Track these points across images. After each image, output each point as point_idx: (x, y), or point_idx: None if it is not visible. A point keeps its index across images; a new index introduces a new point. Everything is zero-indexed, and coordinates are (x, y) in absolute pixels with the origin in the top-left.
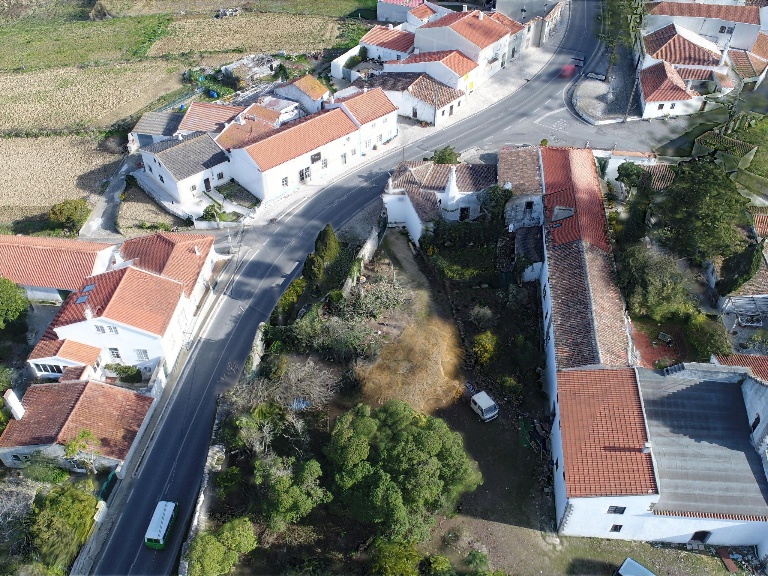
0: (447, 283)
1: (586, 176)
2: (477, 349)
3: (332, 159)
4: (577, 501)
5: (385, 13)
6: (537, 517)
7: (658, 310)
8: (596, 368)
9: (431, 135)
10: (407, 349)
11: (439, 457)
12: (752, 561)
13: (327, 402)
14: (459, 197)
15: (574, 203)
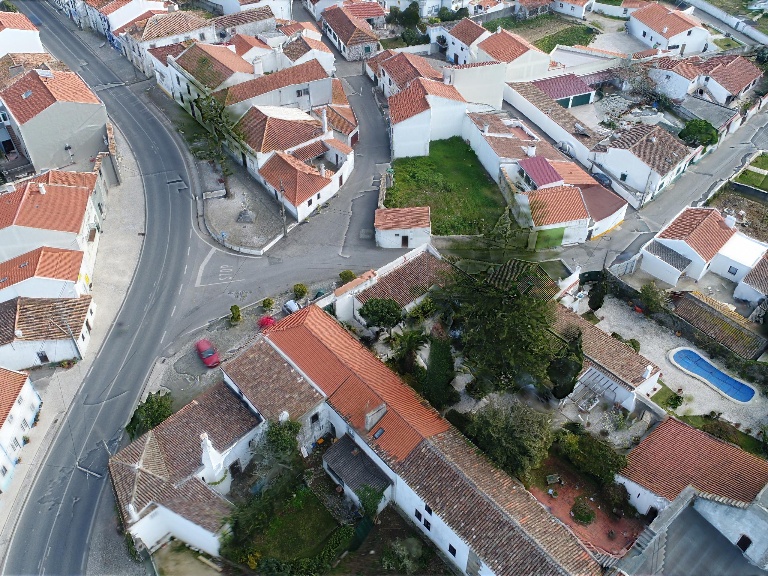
0: None
1: (345, 345)
2: None
3: None
4: None
5: None
6: None
7: None
8: None
9: (88, 375)
10: None
11: None
12: None
13: None
14: (223, 459)
15: (373, 393)
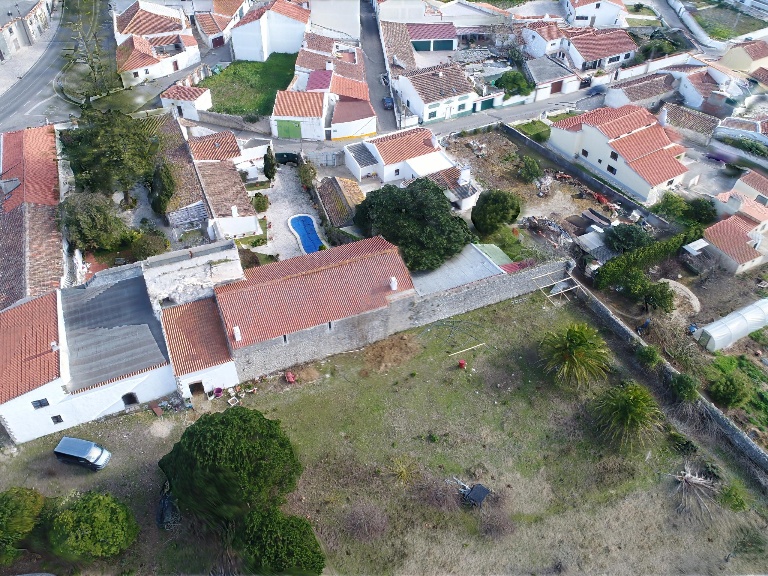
0: None
1: (42, 148)
2: None
3: None
4: None
5: None
6: None
7: (103, 241)
8: (26, 301)
9: None
10: None
11: None
12: (175, 402)
13: None
14: None
15: (22, 174)
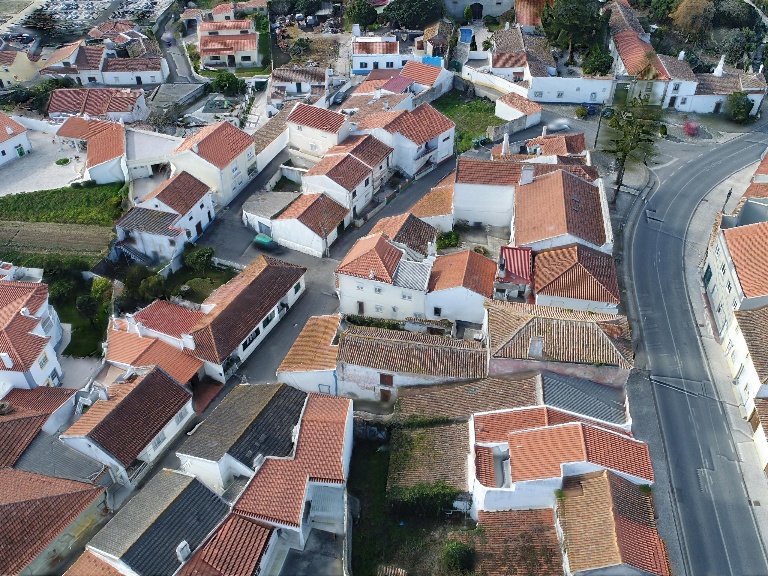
0: None
1: None
2: None
3: None
4: None
5: None
6: None
7: None
8: None
9: None
10: None
11: None
12: None
13: (719, 3)
14: None
15: None
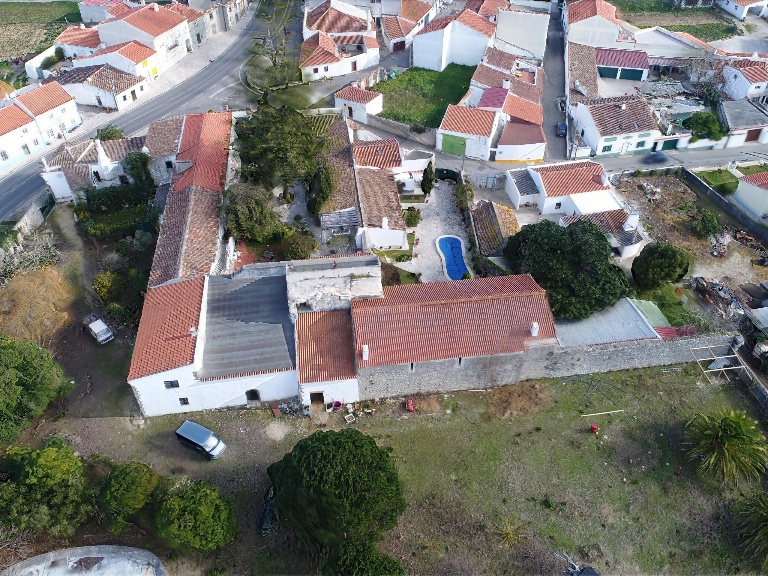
0: (94, 240)
1: (217, 134)
2: (96, 286)
3: (12, 151)
4: (135, 382)
5: (88, 15)
6: (129, 408)
7: (256, 232)
8: (177, 282)
9: (114, 119)
10: (12, 292)
11: (19, 369)
12: (294, 406)
13: None
14: (113, 167)
15: (196, 156)
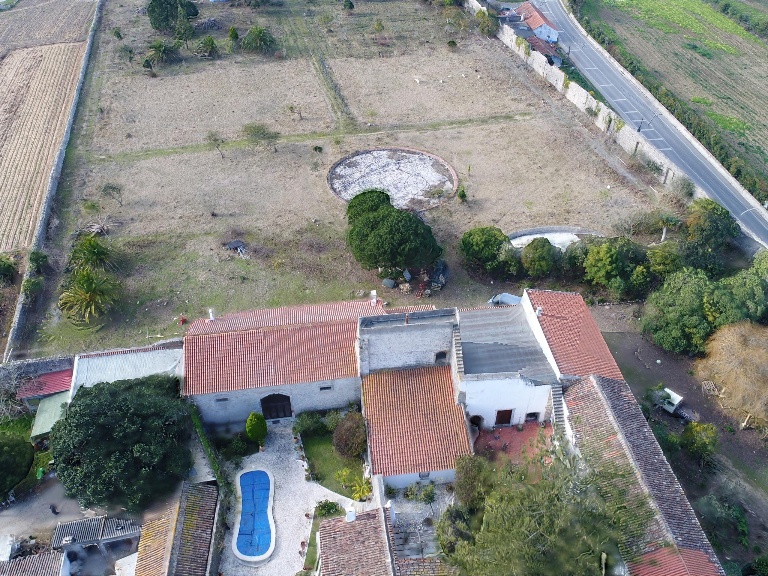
0: None
1: None
2: None
3: None
4: None
5: None
6: None
7: None
8: None
9: None
10: (765, 357)
11: None
12: None
13: None
14: None
15: None
